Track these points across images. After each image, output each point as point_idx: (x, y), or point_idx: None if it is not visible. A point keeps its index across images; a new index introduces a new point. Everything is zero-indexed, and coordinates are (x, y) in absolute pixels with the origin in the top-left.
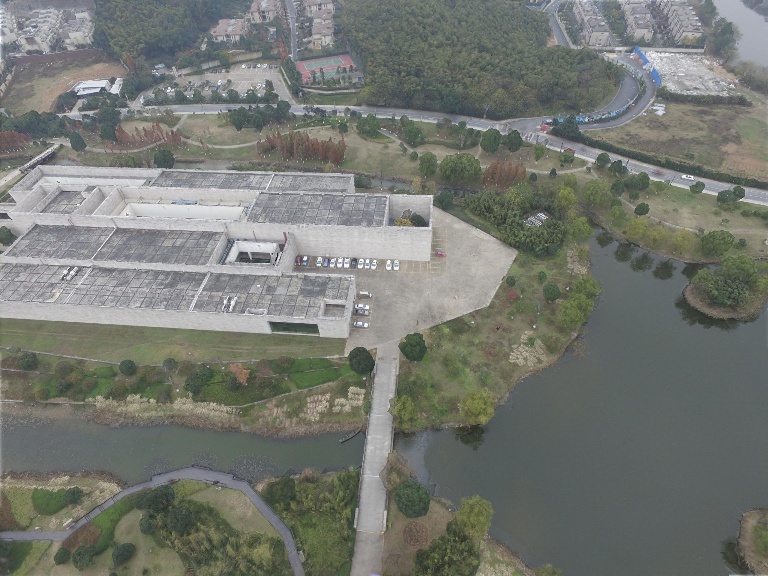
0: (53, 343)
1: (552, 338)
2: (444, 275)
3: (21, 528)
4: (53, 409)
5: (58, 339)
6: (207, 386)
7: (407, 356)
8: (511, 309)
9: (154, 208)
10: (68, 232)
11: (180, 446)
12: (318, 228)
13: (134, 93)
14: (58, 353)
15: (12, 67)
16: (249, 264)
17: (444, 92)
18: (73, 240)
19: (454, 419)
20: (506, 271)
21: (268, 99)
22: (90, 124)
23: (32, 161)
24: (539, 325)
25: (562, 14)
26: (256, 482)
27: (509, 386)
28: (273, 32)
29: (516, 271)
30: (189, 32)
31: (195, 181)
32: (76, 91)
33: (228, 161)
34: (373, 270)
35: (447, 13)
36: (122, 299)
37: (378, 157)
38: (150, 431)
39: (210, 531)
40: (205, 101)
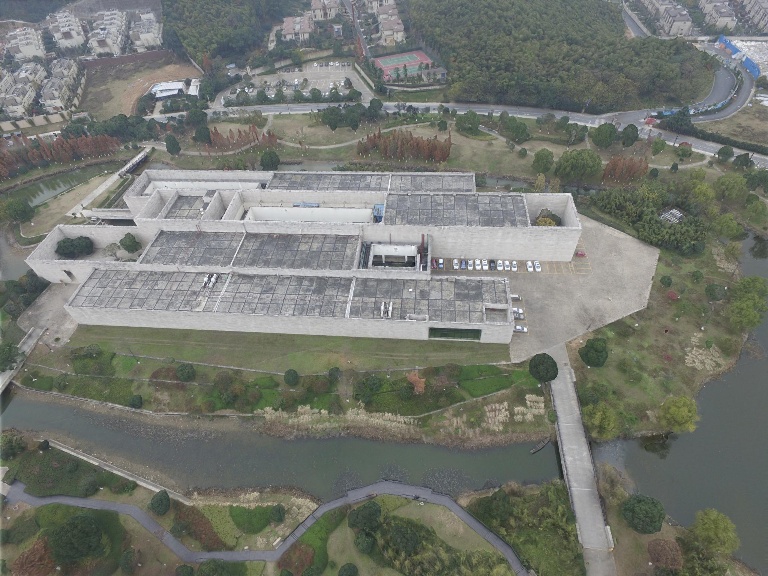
0: (204, 353)
1: (731, 341)
2: (590, 276)
3: (229, 548)
4: (221, 421)
5: (208, 348)
6: (377, 396)
7: (588, 362)
8: (672, 310)
9: (276, 211)
10: (197, 238)
11: (364, 459)
12: (460, 229)
13: (213, 94)
14: (212, 363)
15: (84, 70)
16: (393, 268)
17: (542, 86)
18: (205, 246)
19: (646, 427)
20: (654, 271)
21: (352, 97)
22: (179, 127)
23: (127, 165)
24: (707, 327)
25: (630, 4)
26: (455, 496)
27: (694, 391)
28: (338, 29)
29: (664, 270)
30: (257, 31)
31: (311, 183)
32: (153, 93)
33: (327, 162)
34: (514, 272)
35: (526, 5)
36: (272, 306)
37: (484, 155)
38: (328, 443)
39: (440, 550)
40: (287, 101)
